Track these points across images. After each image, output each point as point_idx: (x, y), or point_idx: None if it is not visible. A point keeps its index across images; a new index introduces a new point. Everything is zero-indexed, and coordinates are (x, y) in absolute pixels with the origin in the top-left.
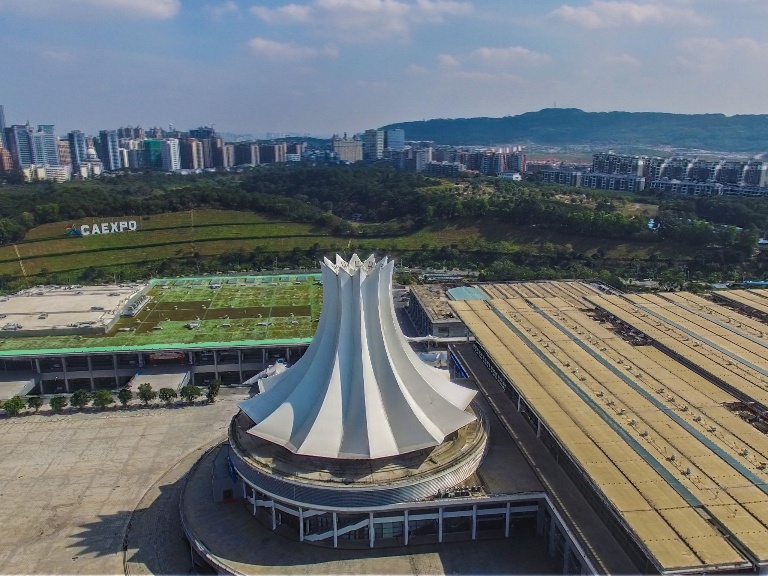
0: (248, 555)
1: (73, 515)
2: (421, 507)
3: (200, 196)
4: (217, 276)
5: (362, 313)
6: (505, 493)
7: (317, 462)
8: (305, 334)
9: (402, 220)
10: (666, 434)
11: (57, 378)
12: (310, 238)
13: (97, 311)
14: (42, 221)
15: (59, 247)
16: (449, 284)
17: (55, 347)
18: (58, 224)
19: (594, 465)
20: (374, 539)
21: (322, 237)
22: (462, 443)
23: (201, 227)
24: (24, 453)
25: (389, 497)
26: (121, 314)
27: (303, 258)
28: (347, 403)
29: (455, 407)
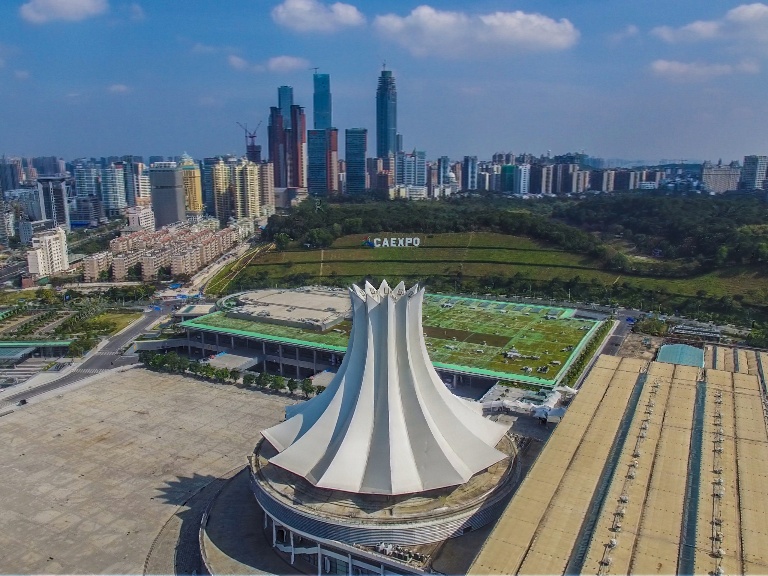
0: (226, 541)
1: (182, 467)
2: (355, 553)
3: (484, 219)
4: (460, 296)
5: (371, 341)
6: (445, 573)
7: (294, 476)
8: (477, 364)
9: (689, 260)
10: (638, 574)
11: (275, 361)
12: (576, 270)
13: (330, 311)
14: (348, 232)
15: (354, 255)
16: (677, 339)
17: (278, 335)
18: (359, 236)
19: (486, 571)
20: (329, 571)
21: (590, 270)
22: (438, 504)
23: (475, 249)
24: (200, 411)
25: (326, 531)
26: (346, 317)
27: (559, 290)
28: (340, 428)
29: (449, 463)
